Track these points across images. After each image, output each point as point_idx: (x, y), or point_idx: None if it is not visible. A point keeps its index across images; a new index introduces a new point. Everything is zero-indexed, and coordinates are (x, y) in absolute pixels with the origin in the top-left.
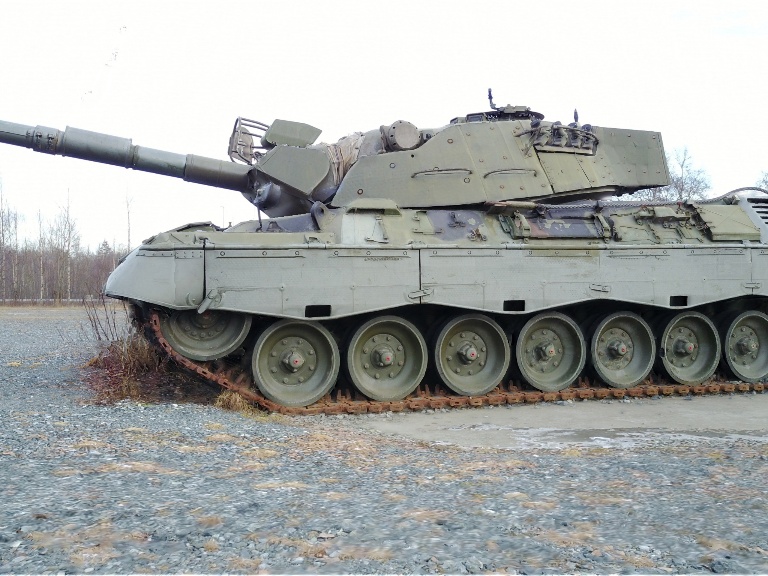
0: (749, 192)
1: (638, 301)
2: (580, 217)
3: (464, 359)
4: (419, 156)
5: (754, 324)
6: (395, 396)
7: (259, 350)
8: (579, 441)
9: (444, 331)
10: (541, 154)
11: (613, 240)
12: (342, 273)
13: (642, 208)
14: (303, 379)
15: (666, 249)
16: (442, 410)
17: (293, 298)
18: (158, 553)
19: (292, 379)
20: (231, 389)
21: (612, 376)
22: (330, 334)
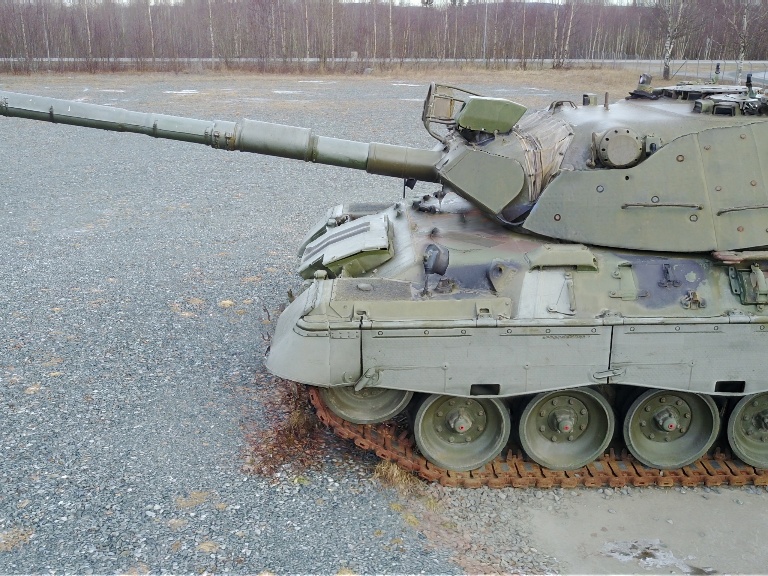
0: None
1: None
2: None
3: (660, 427)
4: (635, 179)
5: None
6: (571, 465)
7: (422, 416)
8: None
9: (638, 401)
10: None
11: None
12: (515, 352)
13: None
14: (470, 439)
15: None
16: (622, 491)
17: (457, 377)
18: None
19: (459, 438)
20: (389, 460)
21: None
22: (501, 402)
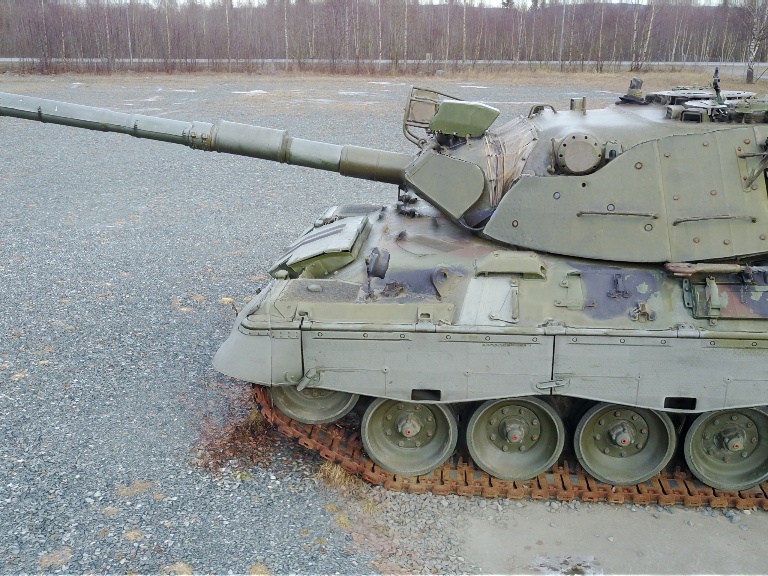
0: None
1: None
2: None
3: (614, 442)
4: (592, 186)
5: None
6: (520, 476)
7: (368, 419)
8: None
9: (588, 414)
10: None
11: None
12: (455, 358)
13: None
14: (420, 444)
15: None
16: (570, 505)
17: (397, 381)
18: None
19: (408, 442)
20: (333, 461)
21: None
22: (447, 408)
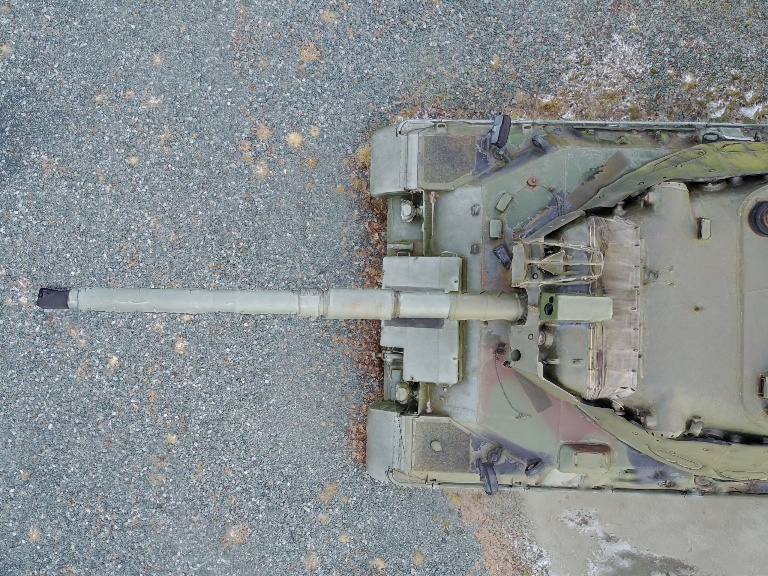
0: None
1: None
2: None
3: None
4: None
5: None
6: None
7: None
8: None
9: None
10: None
11: None
12: None
13: None
14: None
15: None
16: None
17: None
18: None
19: None
20: None
21: None
22: None
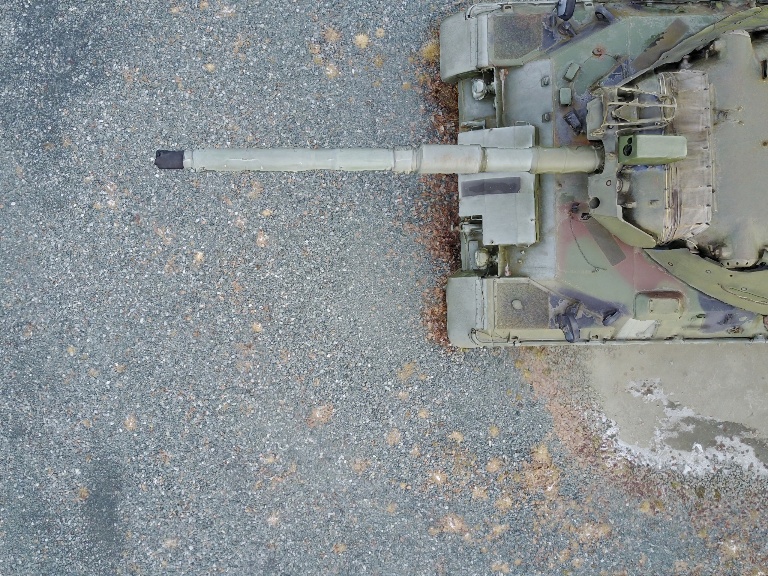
0: None
1: None
2: None
3: None
4: (737, 278)
5: None
6: None
7: None
8: (683, 449)
9: None
10: None
11: None
12: None
13: None
14: None
15: None
16: None
17: None
18: None
19: None
20: None
21: None
22: None
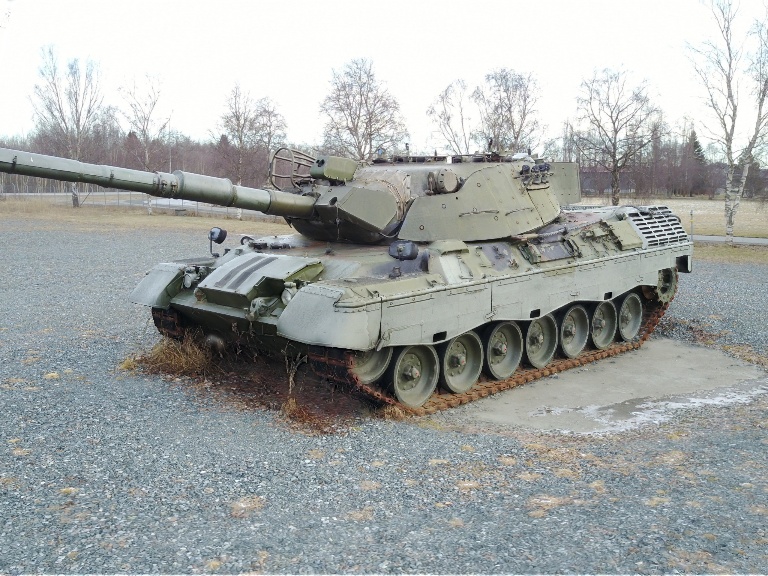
0: (628, 208)
1: (591, 299)
2: (558, 241)
3: (498, 353)
4: (462, 198)
5: (629, 301)
6: (468, 388)
7: None
8: (630, 418)
9: (492, 336)
10: (530, 192)
11: (578, 257)
12: (453, 306)
13: (584, 229)
14: (415, 385)
15: (605, 261)
16: (499, 394)
17: (428, 330)
18: (730, 561)
19: (408, 386)
20: None
21: (567, 350)
22: (435, 350)
